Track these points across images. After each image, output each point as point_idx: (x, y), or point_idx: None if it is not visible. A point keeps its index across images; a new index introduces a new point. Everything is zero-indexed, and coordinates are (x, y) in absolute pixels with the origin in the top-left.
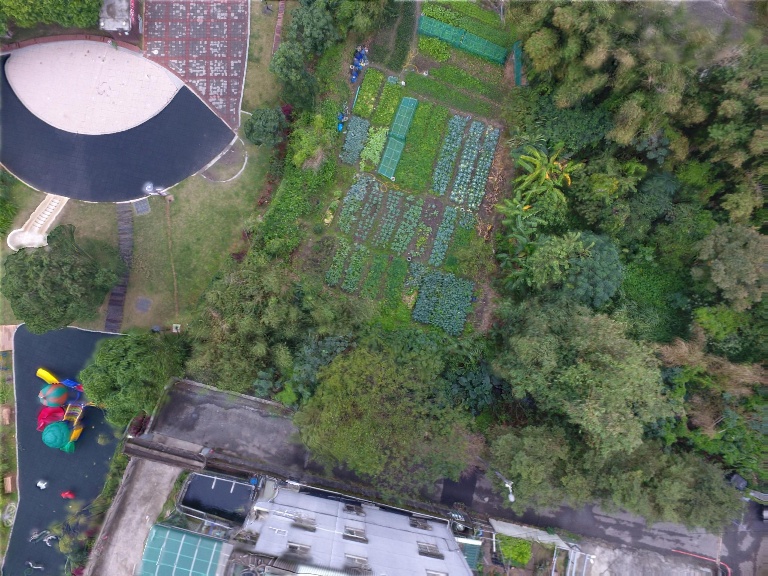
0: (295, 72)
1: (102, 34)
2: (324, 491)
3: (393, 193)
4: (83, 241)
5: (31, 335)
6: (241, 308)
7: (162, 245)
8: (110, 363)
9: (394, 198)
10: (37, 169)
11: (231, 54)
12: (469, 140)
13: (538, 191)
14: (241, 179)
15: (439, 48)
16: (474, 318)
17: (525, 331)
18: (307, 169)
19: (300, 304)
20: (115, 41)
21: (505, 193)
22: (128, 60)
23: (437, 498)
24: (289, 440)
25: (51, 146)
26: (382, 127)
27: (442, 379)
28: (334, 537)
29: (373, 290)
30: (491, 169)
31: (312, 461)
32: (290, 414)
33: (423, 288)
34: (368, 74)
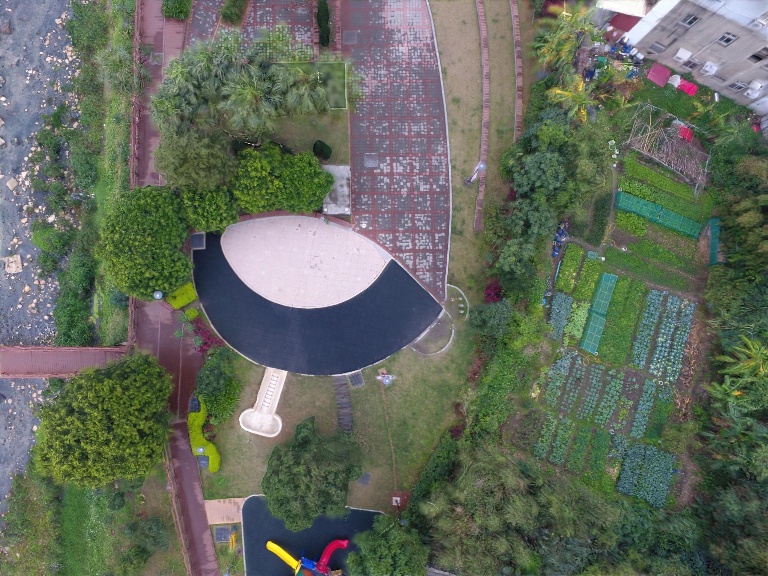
0: (520, 266)
1: None
2: None
3: (595, 367)
4: (306, 417)
5: (259, 508)
6: (484, 505)
7: (380, 420)
8: (385, 575)
9: (596, 372)
10: (256, 343)
11: (435, 227)
12: (666, 314)
13: (749, 380)
14: (449, 352)
15: (637, 224)
16: (674, 488)
17: (753, 528)
18: None
19: (538, 500)
20: (327, 217)
21: (701, 366)
22: (338, 234)
23: None
24: None
25: (268, 320)
26: (583, 302)
27: (652, 554)
28: None
29: (579, 462)
30: (686, 342)
31: None
32: None
33: (627, 461)
34: (569, 249)
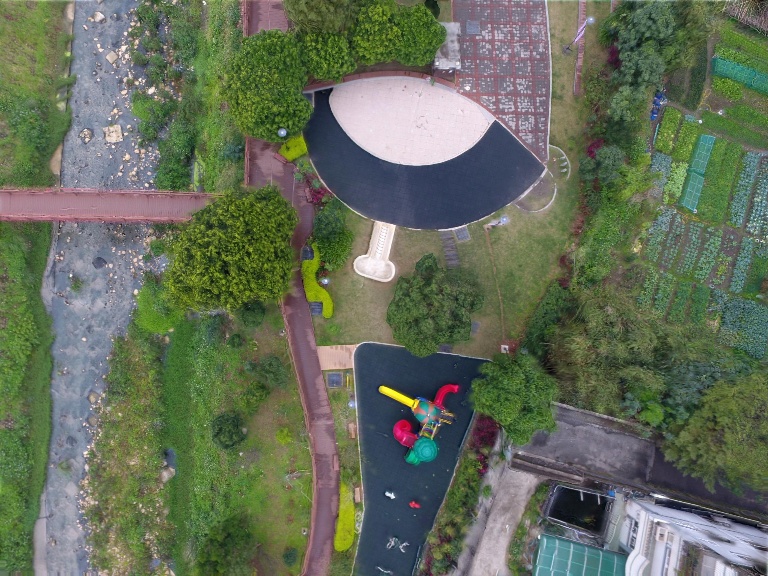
0: (631, 113)
1: (419, 71)
2: (685, 503)
3: (694, 224)
4: None
5: (370, 354)
6: (604, 334)
7: (487, 271)
8: (519, 386)
9: (695, 229)
10: (364, 197)
11: (536, 91)
12: (761, 176)
13: None
14: (553, 209)
15: (731, 89)
16: None
17: None
18: (624, 202)
19: (656, 331)
20: (433, 78)
21: None
22: (442, 95)
23: (767, 510)
24: (632, 455)
25: (376, 176)
26: (682, 162)
27: None
28: (748, 547)
29: (681, 315)
30: None
31: (653, 475)
32: (635, 431)
33: (727, 314)
34: (667, 112)
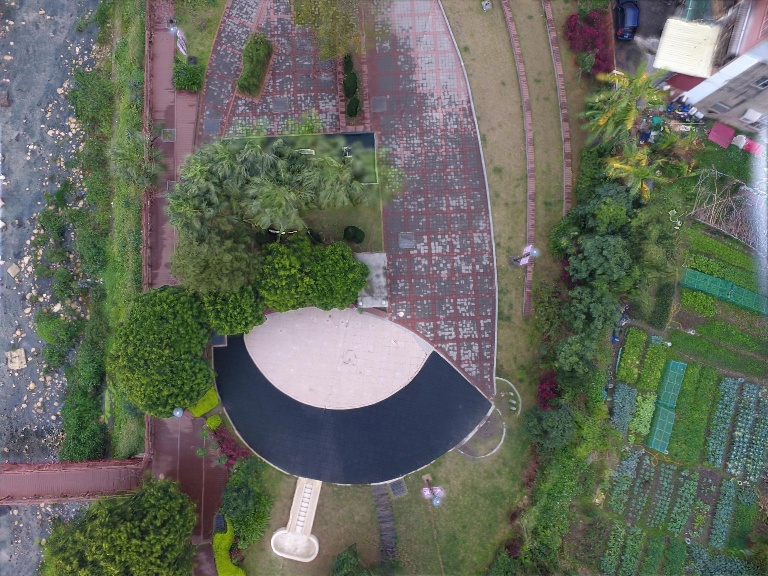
0: (583, 365)
1: None
2: None
3: (665, 467)
4: (345, 536)
5: None
6: None
7: (427, 535)
8: None
9: (667, 472)
10: (286, 450)
11: (480, 313)
12: (742, 404)
13: None
14: (501, 454)
15: (705, 303)
16: None
17: None
18: None
19: None
20: None
21: None
22: (373, 324)
23: None
24: None
25: (299, 424)
26: (649, 393)
27: None
28: None
29: None
30: (766, 434)
31: None
32: None
33: (706, 574)
34: (631, 335)
